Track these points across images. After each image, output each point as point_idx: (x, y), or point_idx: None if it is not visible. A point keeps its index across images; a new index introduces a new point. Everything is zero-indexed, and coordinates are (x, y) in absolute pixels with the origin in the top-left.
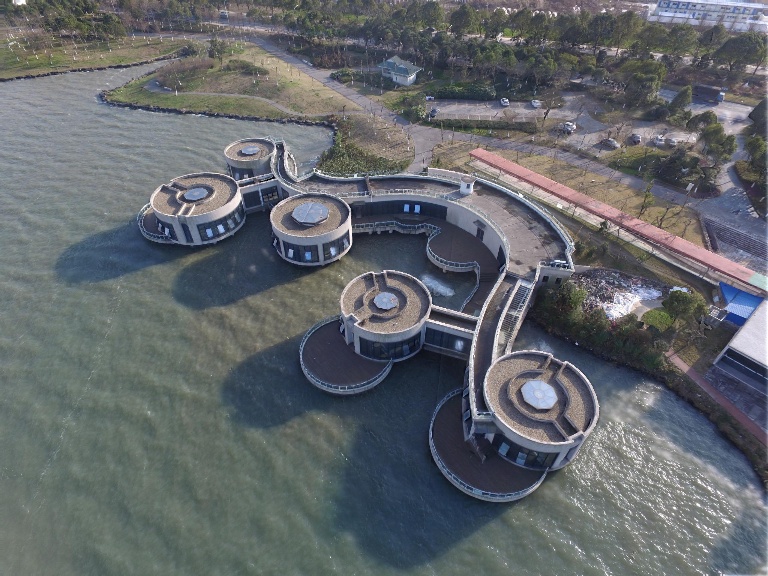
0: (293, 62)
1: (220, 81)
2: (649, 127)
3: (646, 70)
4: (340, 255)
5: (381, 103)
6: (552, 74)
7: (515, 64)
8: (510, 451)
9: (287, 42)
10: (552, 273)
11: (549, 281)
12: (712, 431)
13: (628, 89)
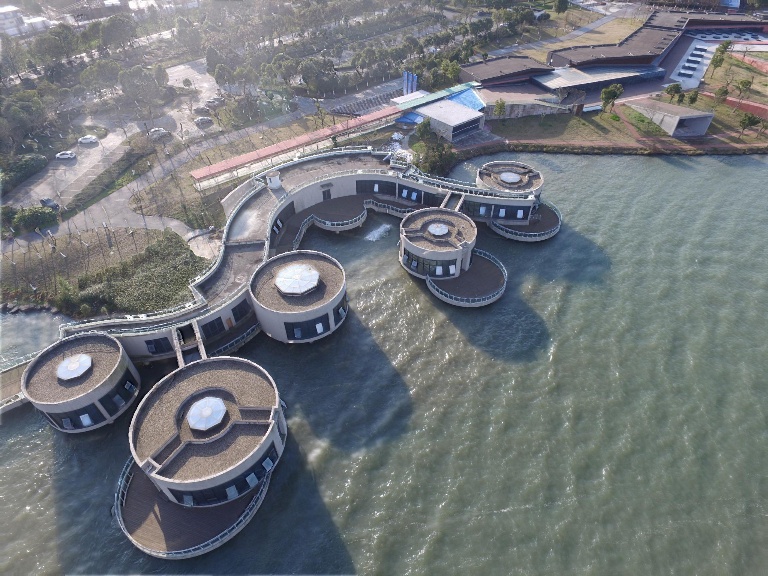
0: None
1: None
2: (183, 103)
3: (109, 70)
4: None
5: None
6: (47, 113)
7: (5, 122)
8: None
9: None
10: None
11: None
12: (489, 157)
13: (128, 87)
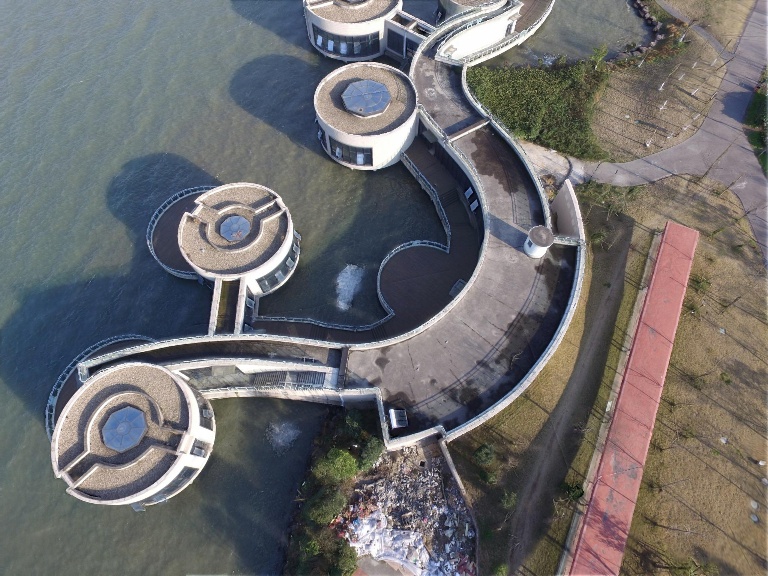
0: None
1: None
2: None
3: None
4: (351, 165)
5: None
6: None
7: None
8: None
9: None
10: None
11: None
12: None
13: None
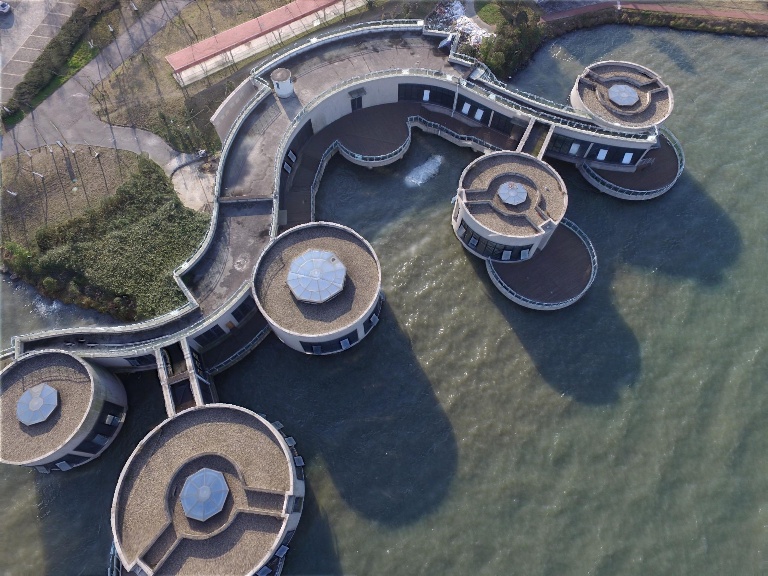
0: None
1: None
2: None
3: None
4: None
5: None
6: None
7: None
8: None
9: None
10: None
11: None
12: (588, 32)
13: None
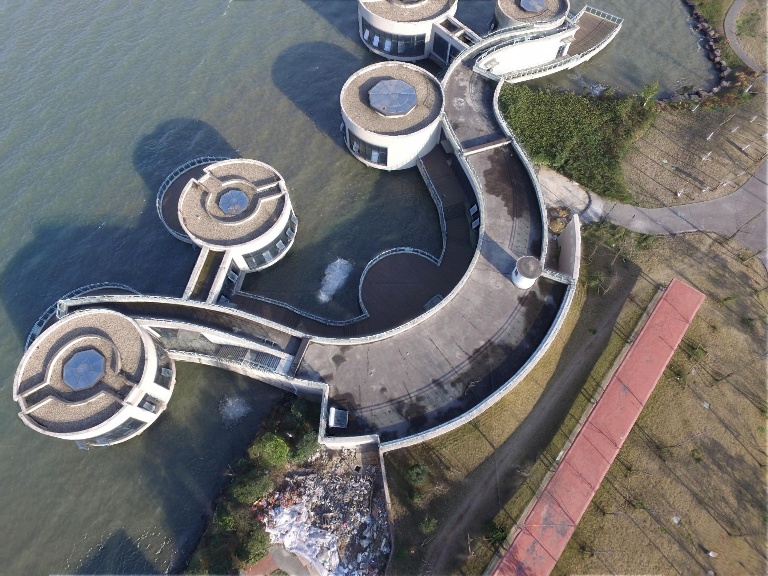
0: None
1: None
2: None
3: None
4: (366, 161)
5: None
6: None
7: None
8: None
9: None
10: None
11: None
12: None
13: None
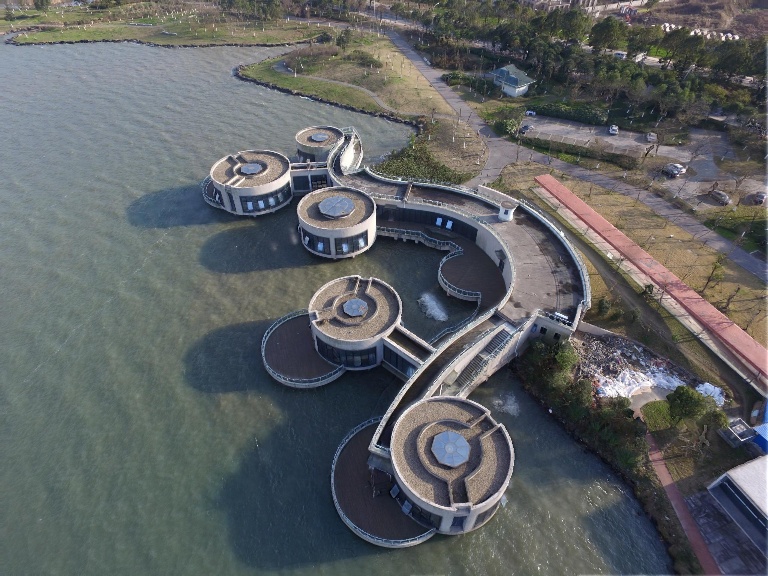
0: (414, 59)
1: (337, 69)
2: None
3: None
4: (354, 253)
5: (477, 111)
6: (685, 106)
7: (642, 89)
8: (400, 496)
9: (418, 39)
10: (550, 326)
11: (547, 334)
12: (665, 565)
13: None
